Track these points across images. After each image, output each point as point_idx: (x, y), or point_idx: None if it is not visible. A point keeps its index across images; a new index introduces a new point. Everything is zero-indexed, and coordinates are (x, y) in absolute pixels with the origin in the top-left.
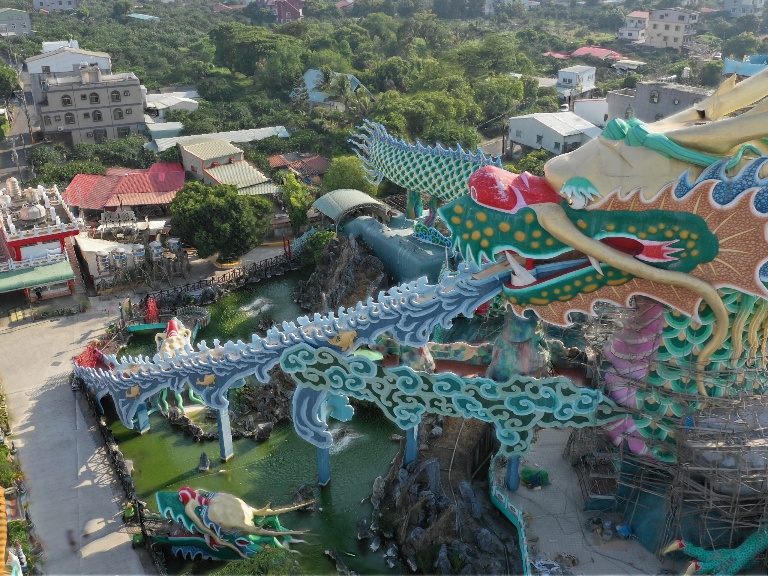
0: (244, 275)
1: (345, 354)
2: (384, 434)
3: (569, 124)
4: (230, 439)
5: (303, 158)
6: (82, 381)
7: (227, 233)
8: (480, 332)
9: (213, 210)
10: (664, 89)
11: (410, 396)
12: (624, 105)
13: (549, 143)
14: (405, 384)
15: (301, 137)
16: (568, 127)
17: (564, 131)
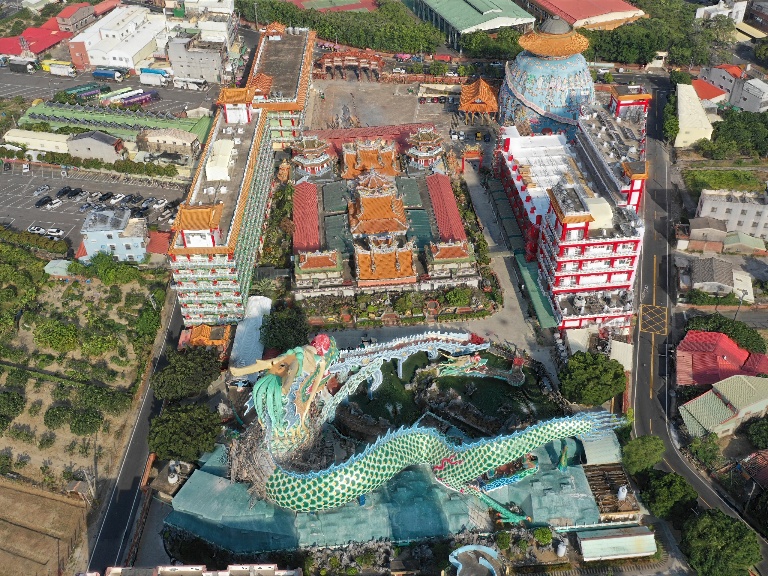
0: None
1: None
2: (390, 422)
3: None
4: (400, 373)
5: None
6: None
7: None
8: None
9: None
10: None
11: None
12: None
13: None
14: None
15: None
16: None
17: None
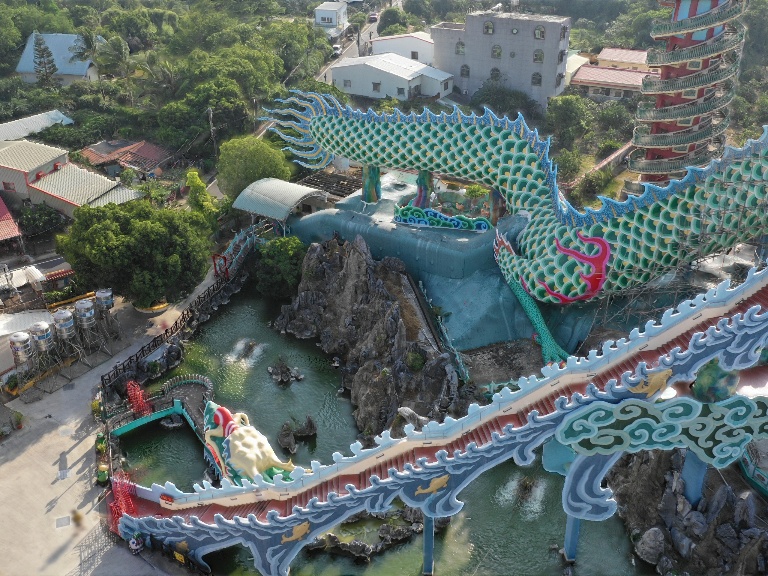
0: (194, 315)
1: (651, 400)
2: None
3: (403, 66)
4: None
5: (117, 147)
6: (150, 537)
7: (178, 267)
8: (588, 320)
9: (151, 240)
10: (499, 19)
11: (738, 428)
12: (453, 40)
13: (390, 90)
14: (736, 416)
15: (94, 121)
16: (405, 70)
17: (405, 75)
